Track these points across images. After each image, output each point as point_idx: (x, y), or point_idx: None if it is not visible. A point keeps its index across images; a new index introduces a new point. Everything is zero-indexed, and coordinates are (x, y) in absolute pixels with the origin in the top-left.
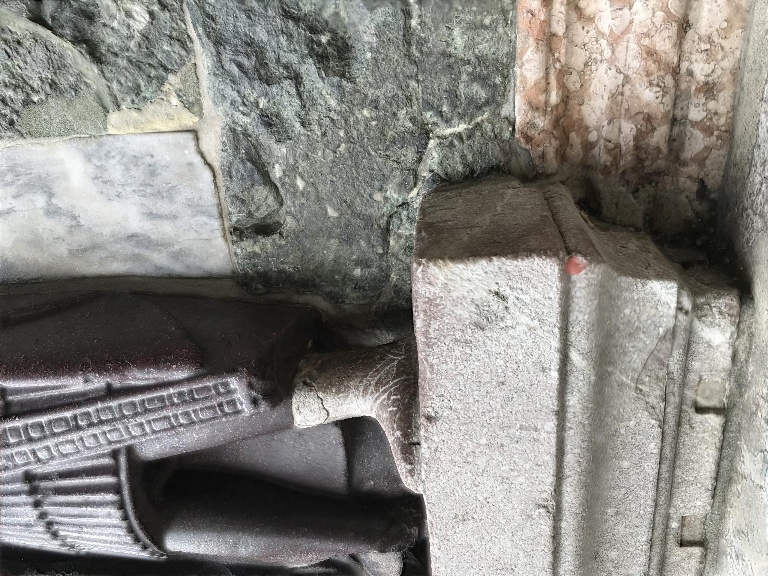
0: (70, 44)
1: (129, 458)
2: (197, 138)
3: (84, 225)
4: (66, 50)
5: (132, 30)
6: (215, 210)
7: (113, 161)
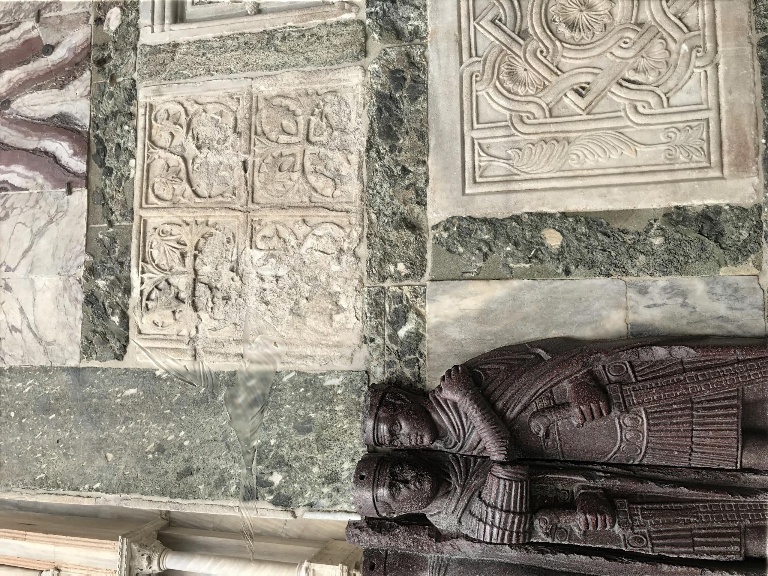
0: (714, 243)
1: (742, 395)
2: (758, 279)
3: (698, 312)
4: (711, 245)
5: (740, 239)
6: (762, 307)
7: (719, 286)
